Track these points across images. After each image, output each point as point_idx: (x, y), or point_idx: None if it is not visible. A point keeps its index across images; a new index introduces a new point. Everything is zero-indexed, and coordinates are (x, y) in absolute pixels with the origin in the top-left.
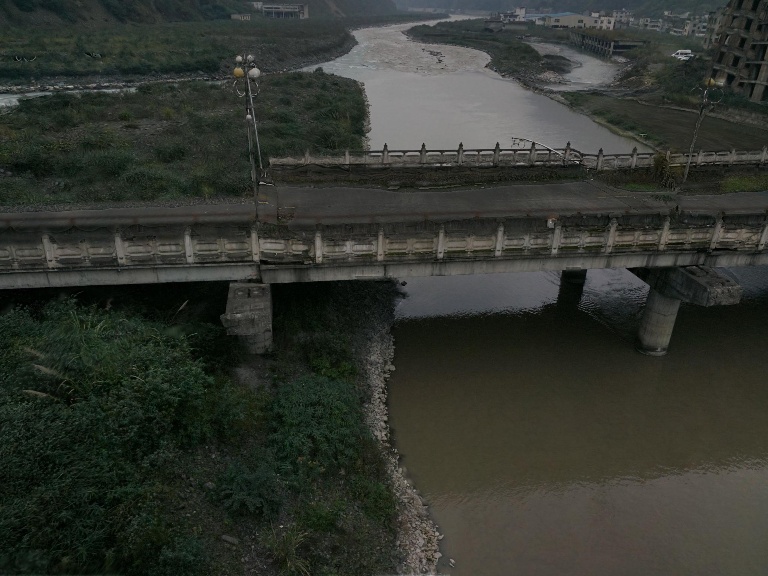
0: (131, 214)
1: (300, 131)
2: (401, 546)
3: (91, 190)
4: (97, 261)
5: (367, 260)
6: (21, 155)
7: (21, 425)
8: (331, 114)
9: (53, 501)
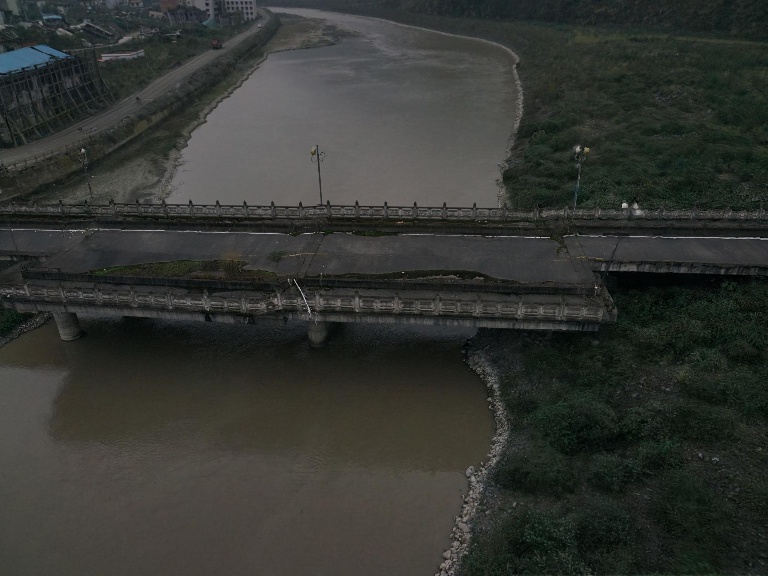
0: (669, 255)
1: None
2: None
3: None
4: None
5: None
6: None
7: None
8: None
9: None
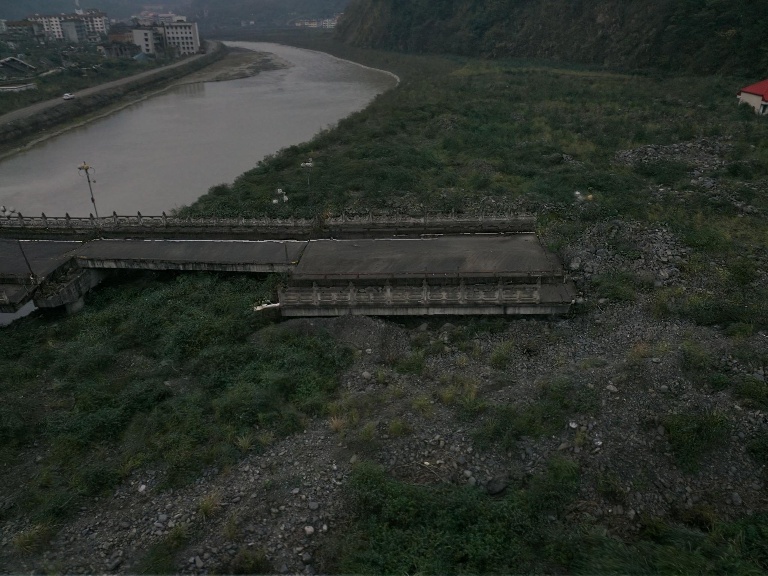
0: (146, 254)
1: None
2: None
3: None
4: None
5: None
6: (197, 426)
7: None
8: None
9: None
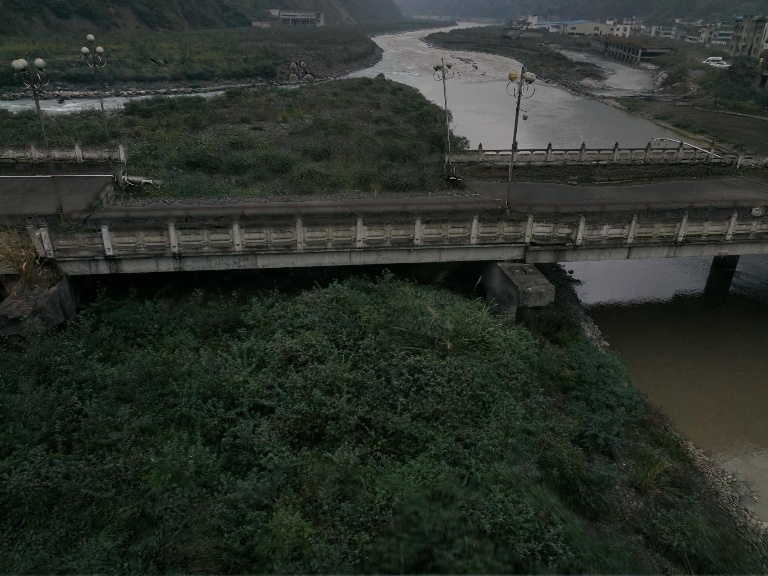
0: (368, 204)
1: (412, 133)
2: (707, 486)
3: (263, 186)
4: (396, 242)
5: (618, 243)
6: (183, 154)
7: (431, 372)
8: (422, 118)
9: (499, 430)
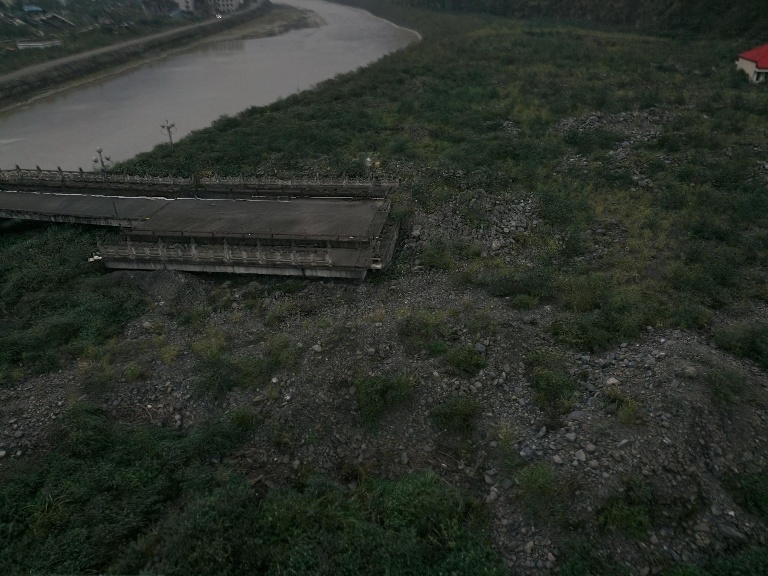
0: (25, 205)
1: None
2: None
3: None
4: None
5: None
6: None
7: (121, 169)
8: None
9: None
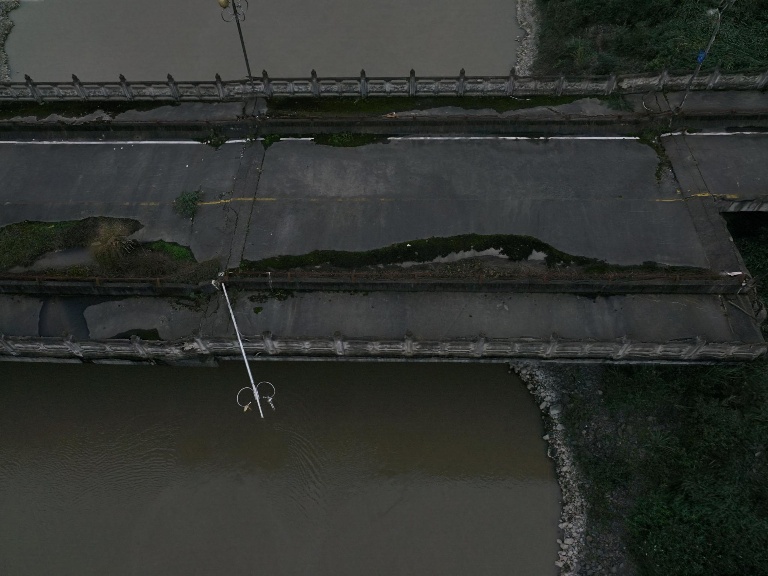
0: None
1: None
2: None
3: None
4: None
5: None
6: None
7: None
8: None
9: None
